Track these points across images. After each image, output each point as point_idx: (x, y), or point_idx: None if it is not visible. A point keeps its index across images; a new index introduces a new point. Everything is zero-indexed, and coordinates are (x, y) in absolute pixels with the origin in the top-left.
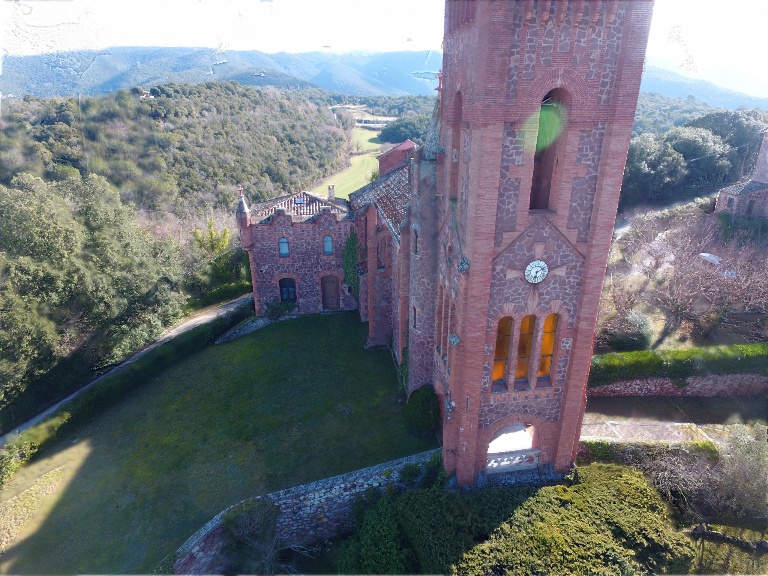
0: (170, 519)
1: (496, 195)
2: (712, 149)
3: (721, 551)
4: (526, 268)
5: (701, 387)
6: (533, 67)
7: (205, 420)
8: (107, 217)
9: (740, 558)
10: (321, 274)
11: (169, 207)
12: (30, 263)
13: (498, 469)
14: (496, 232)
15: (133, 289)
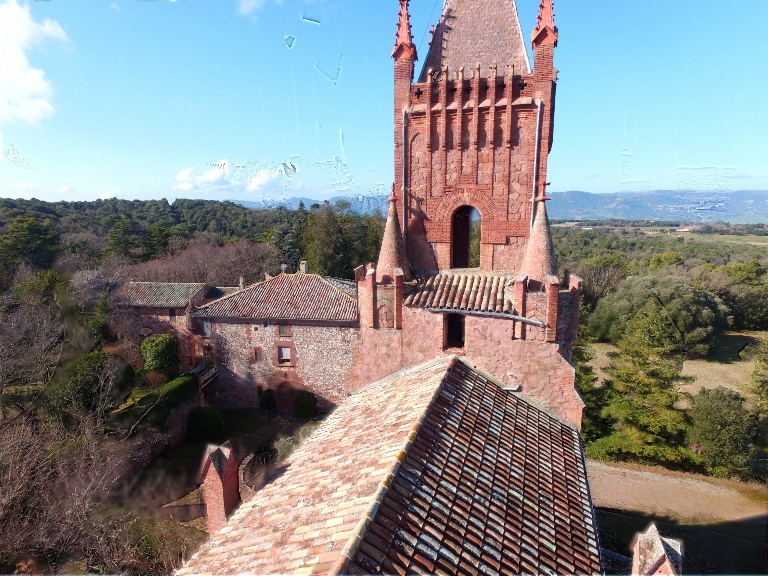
0: None
1: None
2: None
3: None
4: None
5: None
6: None
7: None
8: None
9: None
10: None
11: None
12: None
13: None
14: None
15: None
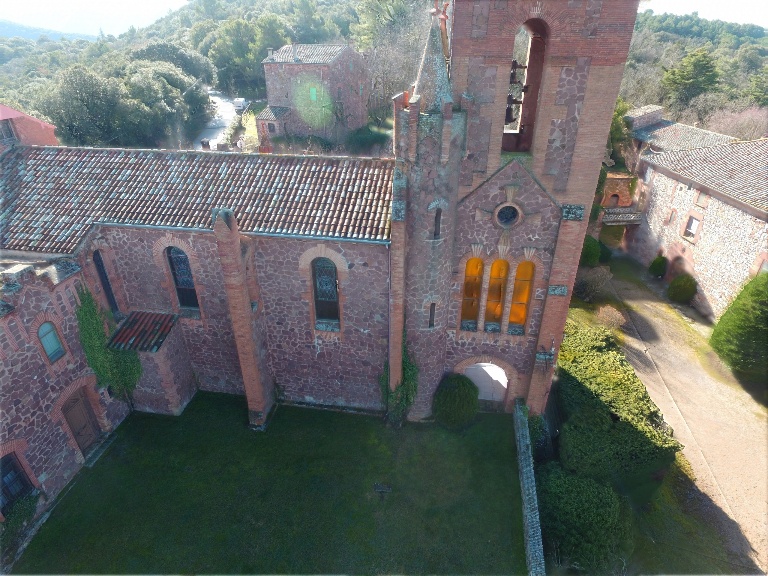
0: None
1: None
2: (186, 82)
3: None
4: None
5: None
6: None
7: None
8: None
9: None
10: (58, 402)
11: None
12: None
13: None
14: None
15: None
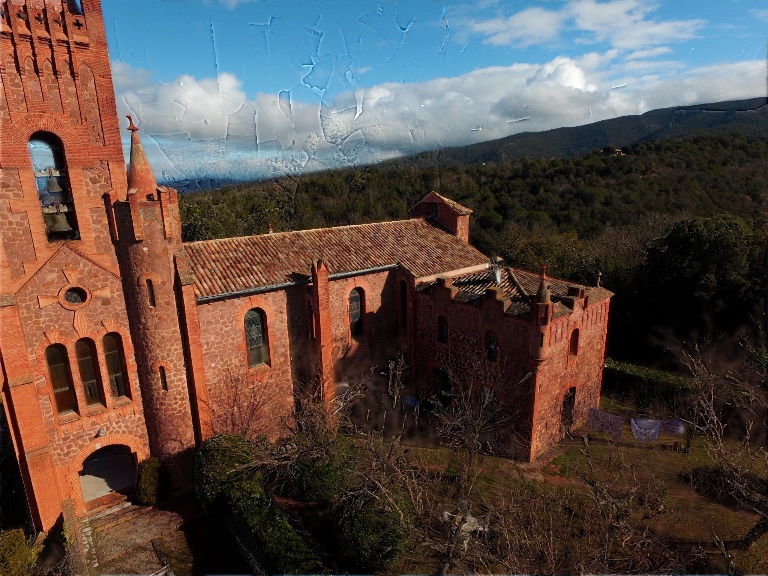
0: None
1: None
2: None
3: None
4: None
5: None
6: None
7: None
8: None
9: None
10: None
11: None
12: None
13: None
14: None
15: None
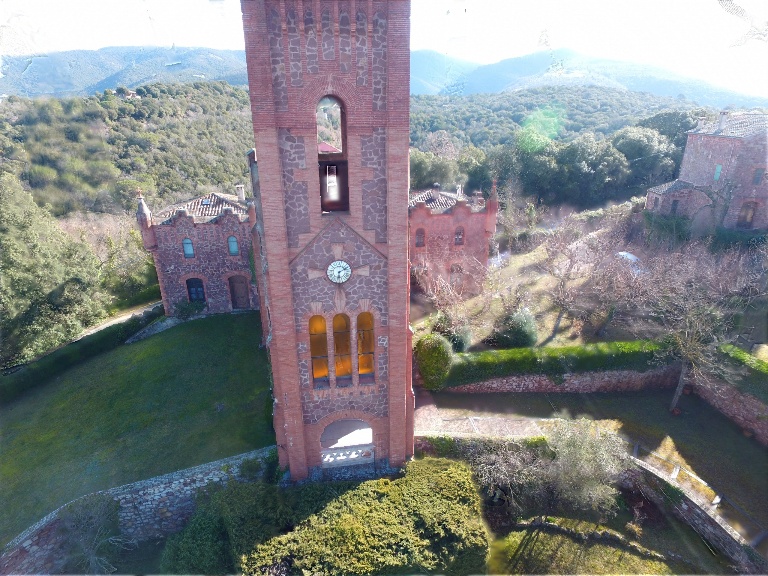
0: (18, 514)
1: (280, 198)
2: (656, 149)
3: (553, 542)
4: (328, 268)
5: (579, 383)
6: (301, 75)
7: (85, 418)
8: (15, 219)
9: (569, 549)
10: (228, 274)
11: (121, 208)
12: None
13: (335, 464)
14: (291, 233)
15: (37, 290)
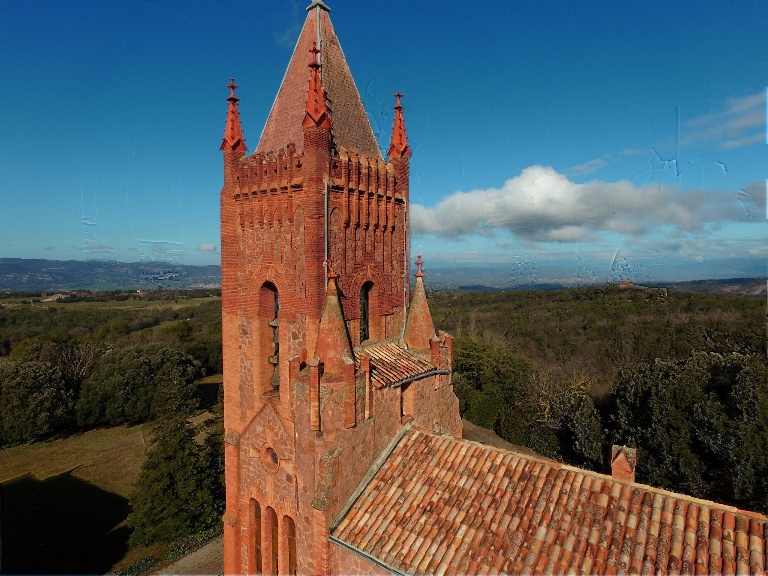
0: None
1: None
2: None
3: None
4: None
5: None
6: None
7: None
8: None
9: None
10: None
11: None
12: (713, 408)
13: None
14: None
15: None
